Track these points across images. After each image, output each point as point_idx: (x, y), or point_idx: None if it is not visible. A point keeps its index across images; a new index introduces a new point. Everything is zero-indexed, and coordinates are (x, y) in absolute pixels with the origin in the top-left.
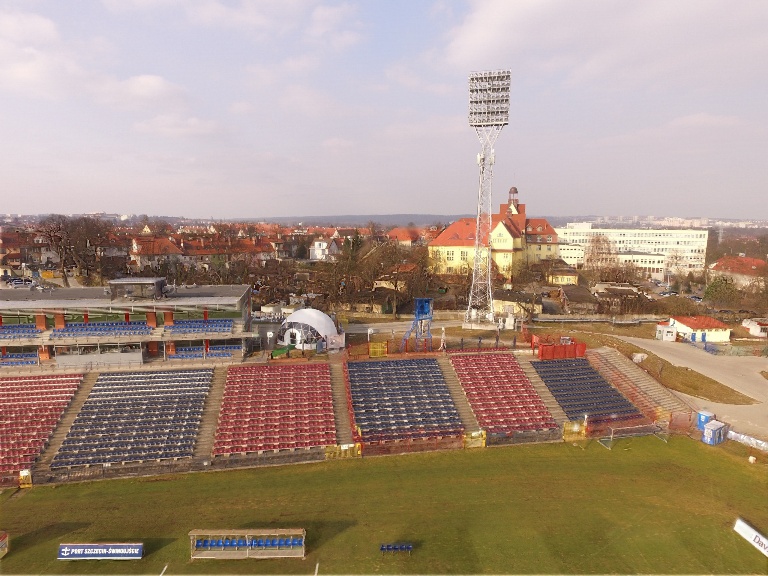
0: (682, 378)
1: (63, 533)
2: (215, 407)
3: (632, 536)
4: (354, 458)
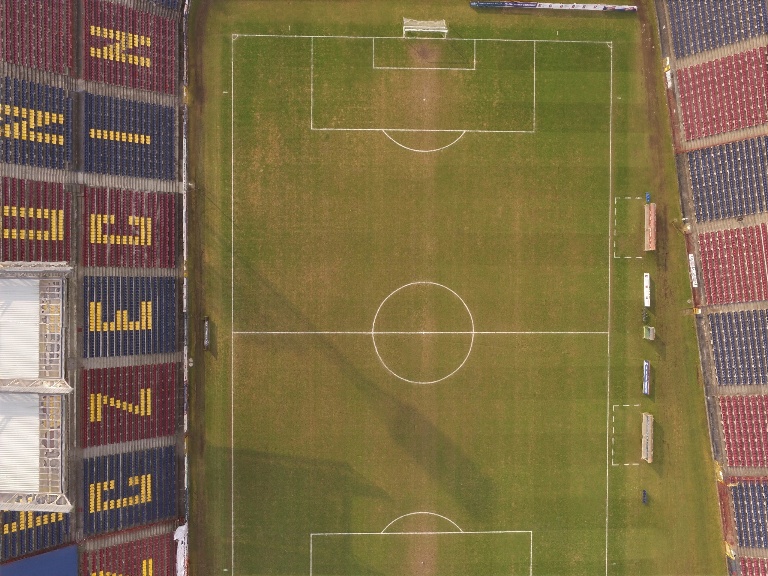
0: None
1: (659, 353)
2: (765, 391)
3: None
4: (715, 476)
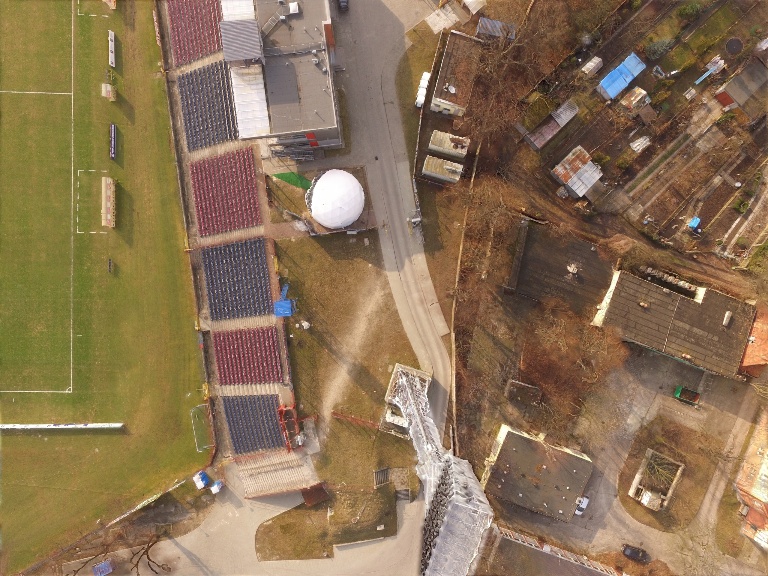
0: (304, 532)
1: (127, 117)
2: (220, 150)
3: (119, 373)
4: None
